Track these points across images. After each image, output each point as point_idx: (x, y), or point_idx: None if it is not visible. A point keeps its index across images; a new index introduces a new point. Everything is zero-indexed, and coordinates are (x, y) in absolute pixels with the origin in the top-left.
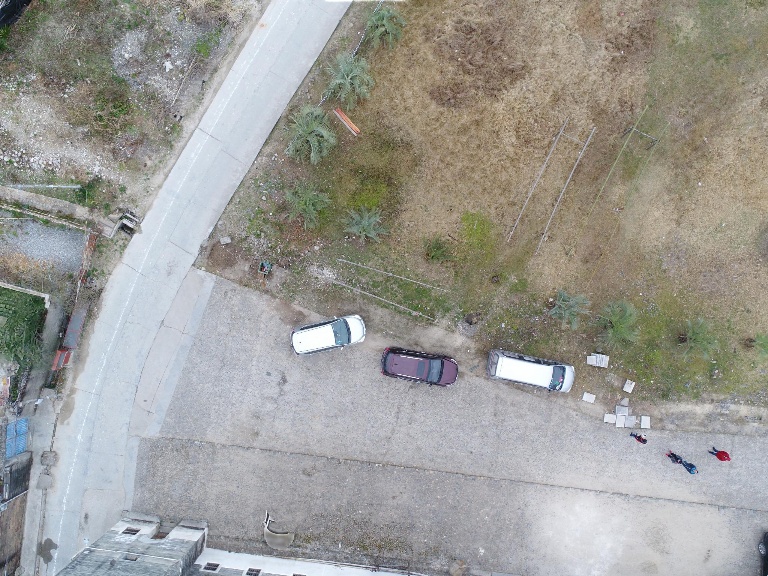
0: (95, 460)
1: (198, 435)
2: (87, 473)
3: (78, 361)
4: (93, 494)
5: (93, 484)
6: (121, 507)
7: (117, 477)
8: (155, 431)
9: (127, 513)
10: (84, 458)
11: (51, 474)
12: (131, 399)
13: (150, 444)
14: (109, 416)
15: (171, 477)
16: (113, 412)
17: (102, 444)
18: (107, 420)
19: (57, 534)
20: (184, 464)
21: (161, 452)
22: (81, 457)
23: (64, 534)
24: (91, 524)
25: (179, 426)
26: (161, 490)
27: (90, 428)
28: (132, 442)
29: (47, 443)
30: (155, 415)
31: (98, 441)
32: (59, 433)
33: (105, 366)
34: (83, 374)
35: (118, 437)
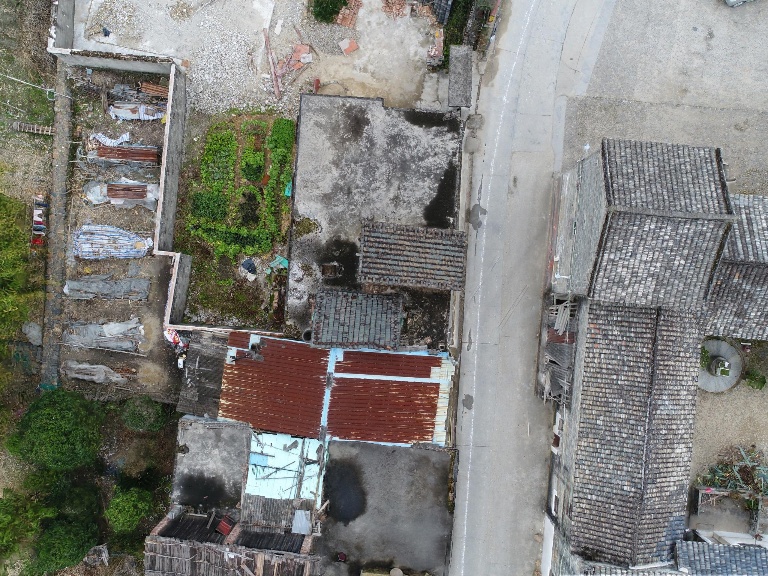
0: (522, 122)
1: (625, 94)
2: (514, 135)
3: (500, 21)
4: (521, 157)
5: (521, 146)
6: (551, 169)
7: (545, 138)
8: (582, 90)
9: (558, 174)
10: (510, 120)
11: (477, 138)
12: (557, 57)
13: (578, 103)
14: (535, 76)
15: (600, 137)
16: (539, 71)
17: (529, 105)
18: (533, 80)
19: (486, 199)
20: (613, 123)
21: (589, 111)
22: (507, 119)
23: (493, 199)
24: (520, 187)
25: (606, 85)
26: (590, 151)
27: (516, 89)
28: (560, 102)
29: (472, 106)
30: (581, 74)
31: (524, 102)
32: (483, 95)
33: (529, 24)
34: (506, 34)
35: (545, 97)
